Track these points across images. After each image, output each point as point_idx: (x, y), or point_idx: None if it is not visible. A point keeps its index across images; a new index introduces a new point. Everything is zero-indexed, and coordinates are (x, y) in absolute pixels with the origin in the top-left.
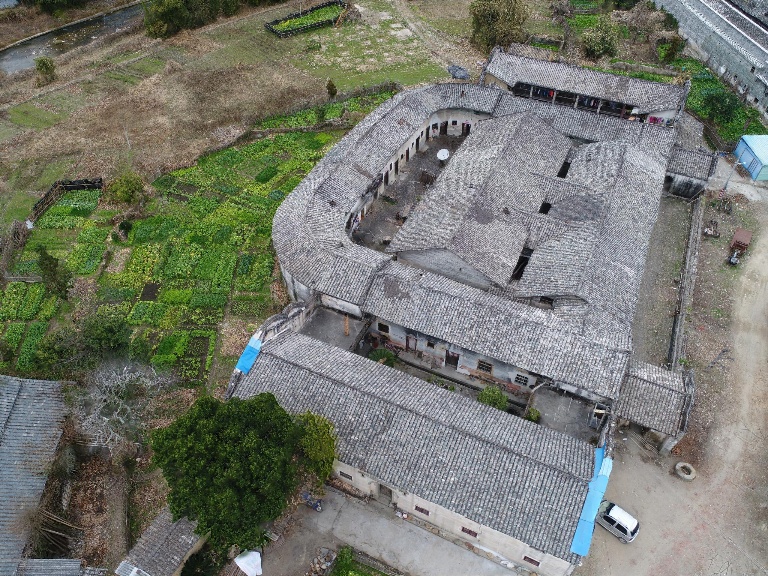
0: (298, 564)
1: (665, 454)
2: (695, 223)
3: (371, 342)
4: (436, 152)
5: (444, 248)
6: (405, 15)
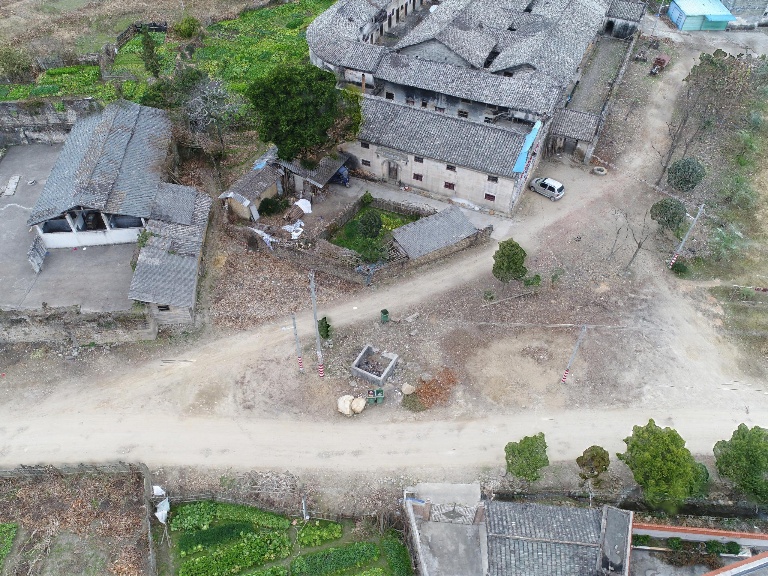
0: (335, 209)
1: (587, 163)
2: None
3: None
4: (429, 11)
5: (434, 39)
6: None
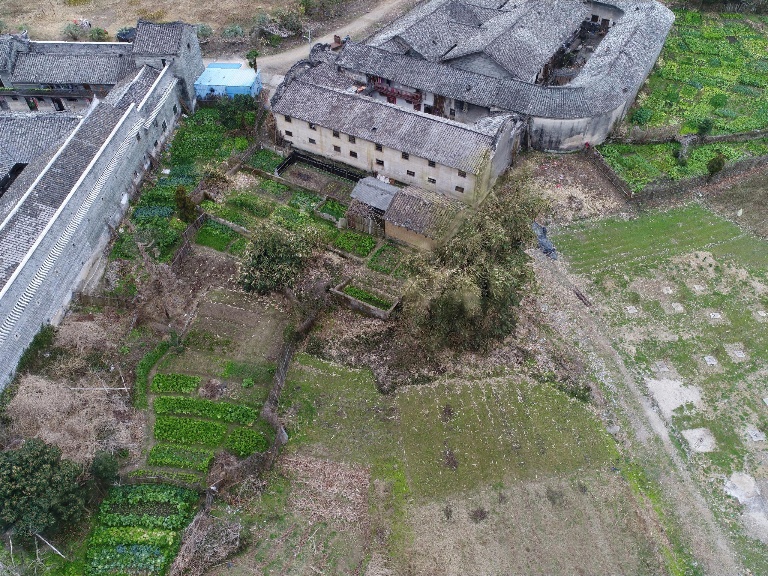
0: None
1: None
2: None
3: None
4: None
5: None
6: (694, 496)
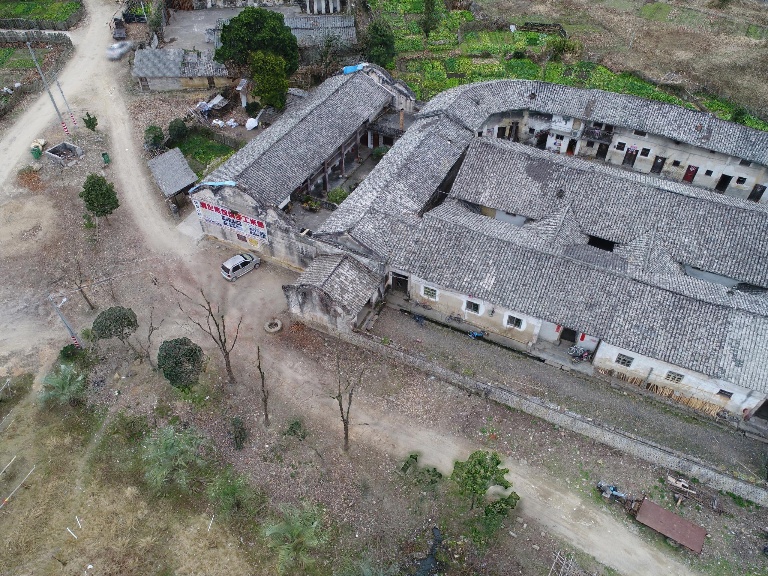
0: None
1: None
2: None
3: None
4: None
5: None
6: None
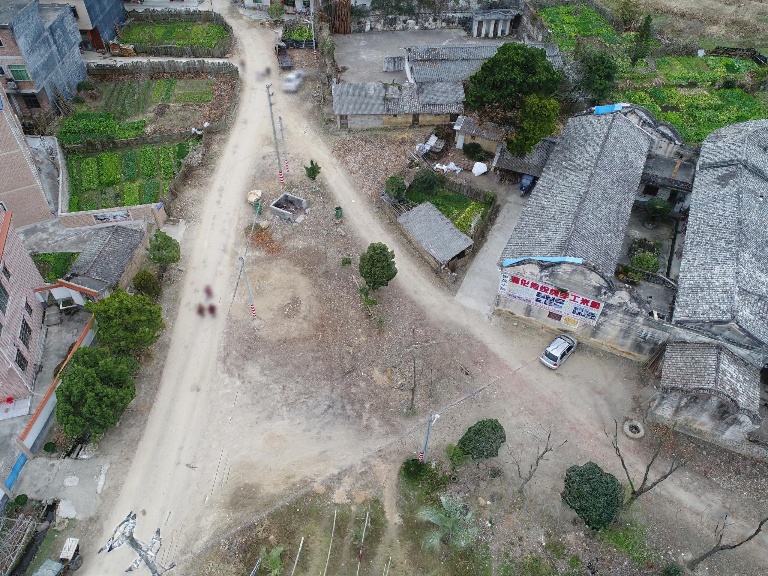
0: (485, 189)
1: None
2: None
3: (685, 216)
4: None
5: None
6: None
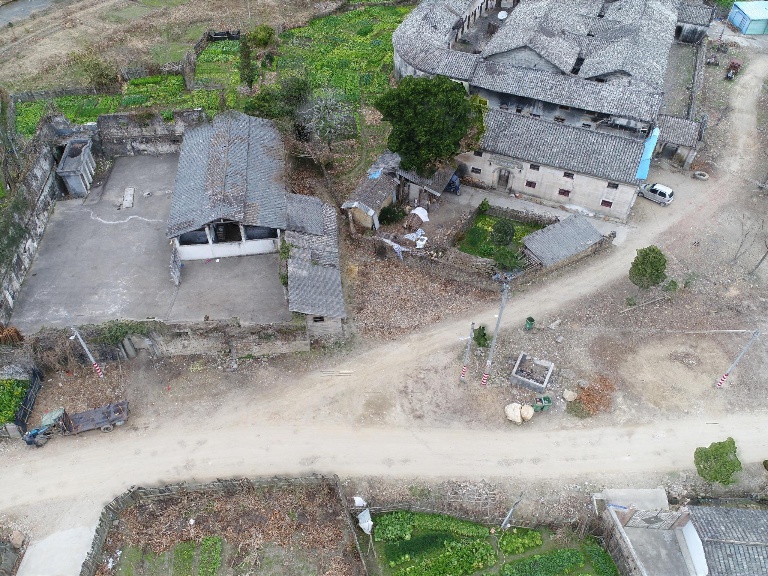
0: (451, 217)
1: (687, 168)
2: (700, 56)
3: None
4: (495, 17)
5: (525, 46)
6: None
